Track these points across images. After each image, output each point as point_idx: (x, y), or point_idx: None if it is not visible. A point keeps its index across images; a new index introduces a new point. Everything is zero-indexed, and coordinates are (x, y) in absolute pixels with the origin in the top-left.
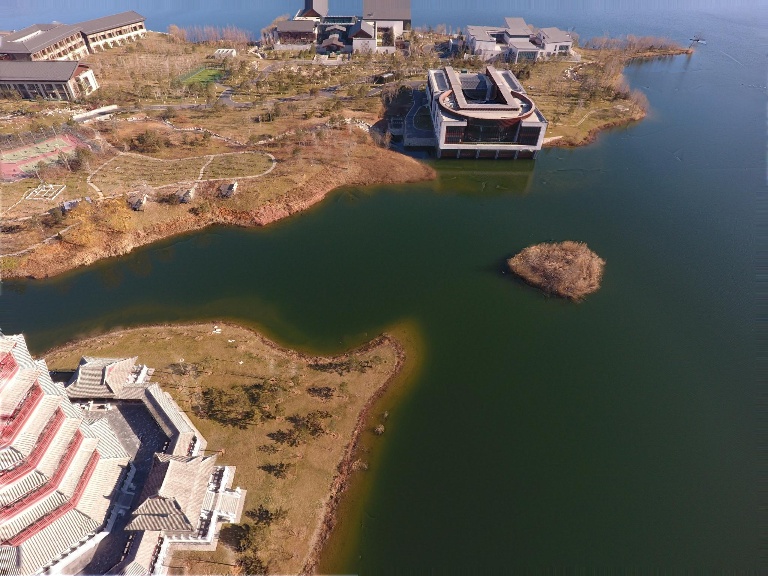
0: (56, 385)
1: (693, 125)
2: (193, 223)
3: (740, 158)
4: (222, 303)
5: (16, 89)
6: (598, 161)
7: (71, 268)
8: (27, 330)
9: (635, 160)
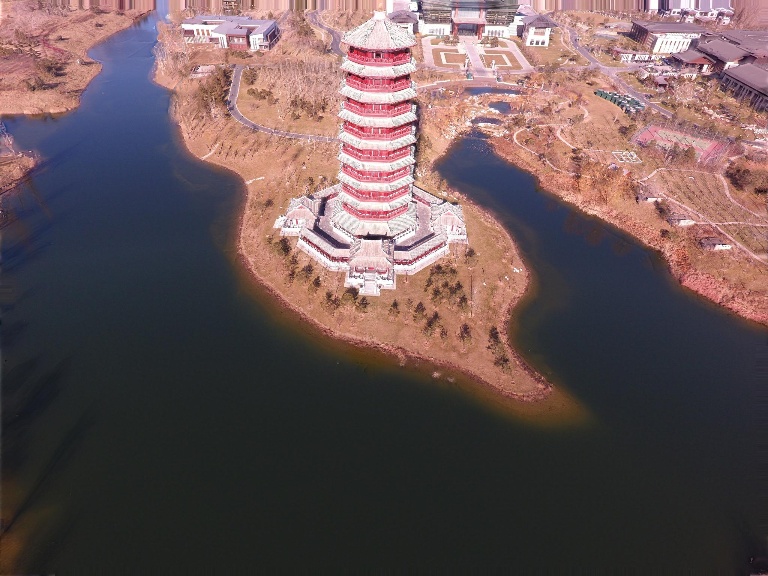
0: (412, 179)
1: None
2: (649, 238)
3: None
4: (553, 272)
5: (760, 102)
6: None
7: (557, 194)
8: (494, 195)
9: None
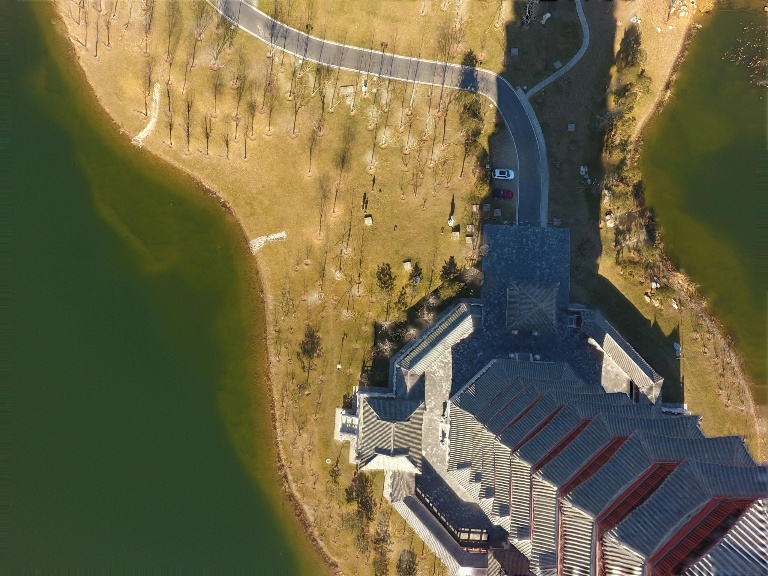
0: None
1: None
2: None
3: None
4: None
5: None
6: None
7: None
8: (751, 266)
9: None
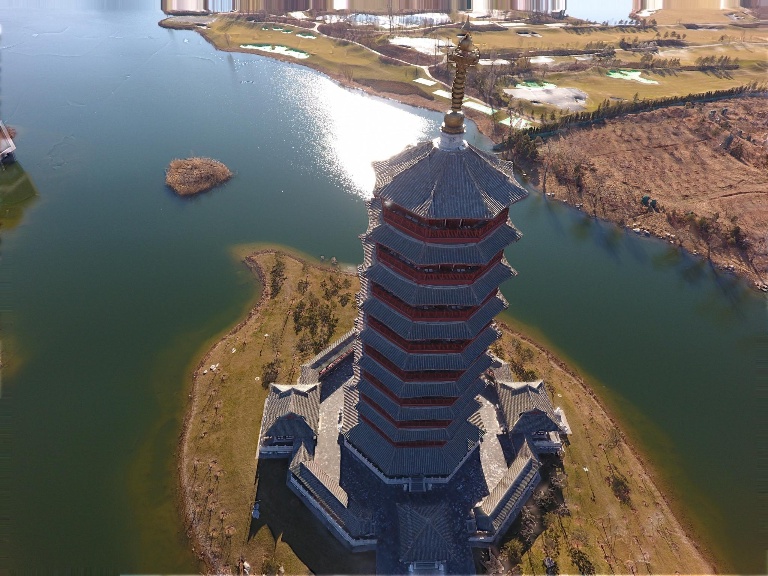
0: None
1: (31, 87)
2: None
3: (100, 87)
4: (158, 382)
5: None
6: (50, 135)
7: None
8: None
9: (64, 121)
